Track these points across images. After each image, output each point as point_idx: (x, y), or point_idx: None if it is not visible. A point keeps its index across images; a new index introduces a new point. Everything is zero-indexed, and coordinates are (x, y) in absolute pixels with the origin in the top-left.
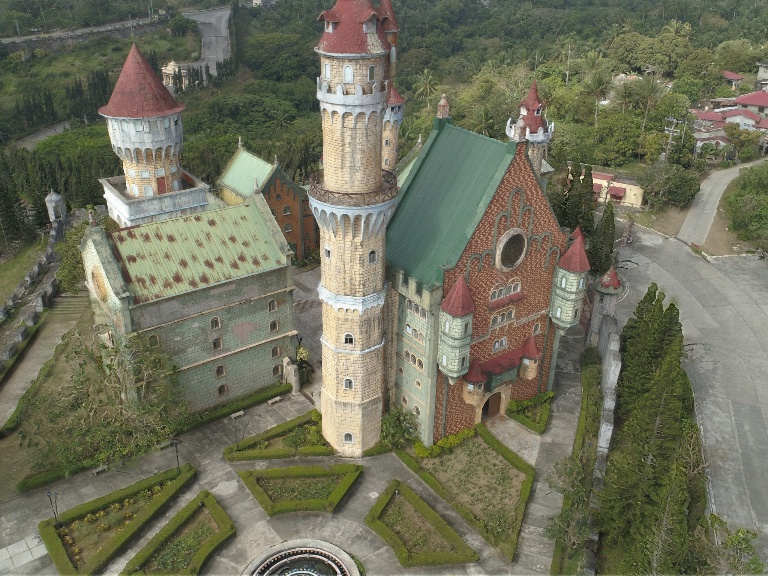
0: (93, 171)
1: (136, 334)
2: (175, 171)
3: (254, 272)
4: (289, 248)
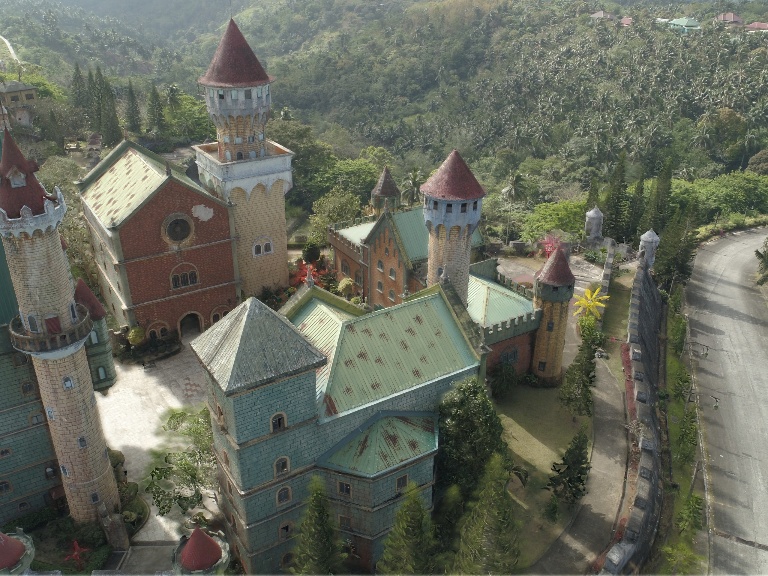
0: (682, 216)
1: (82, 215)
2: (229, 142)
3: (105, 224)
4: (117, 224)
